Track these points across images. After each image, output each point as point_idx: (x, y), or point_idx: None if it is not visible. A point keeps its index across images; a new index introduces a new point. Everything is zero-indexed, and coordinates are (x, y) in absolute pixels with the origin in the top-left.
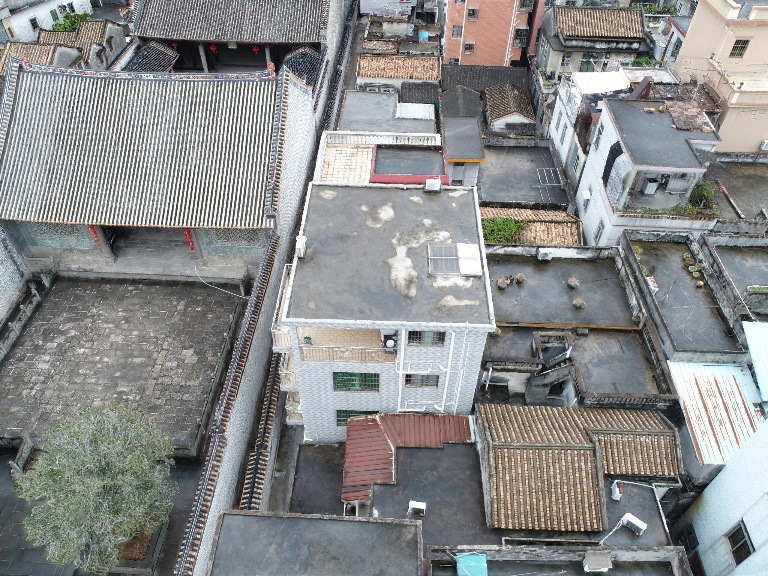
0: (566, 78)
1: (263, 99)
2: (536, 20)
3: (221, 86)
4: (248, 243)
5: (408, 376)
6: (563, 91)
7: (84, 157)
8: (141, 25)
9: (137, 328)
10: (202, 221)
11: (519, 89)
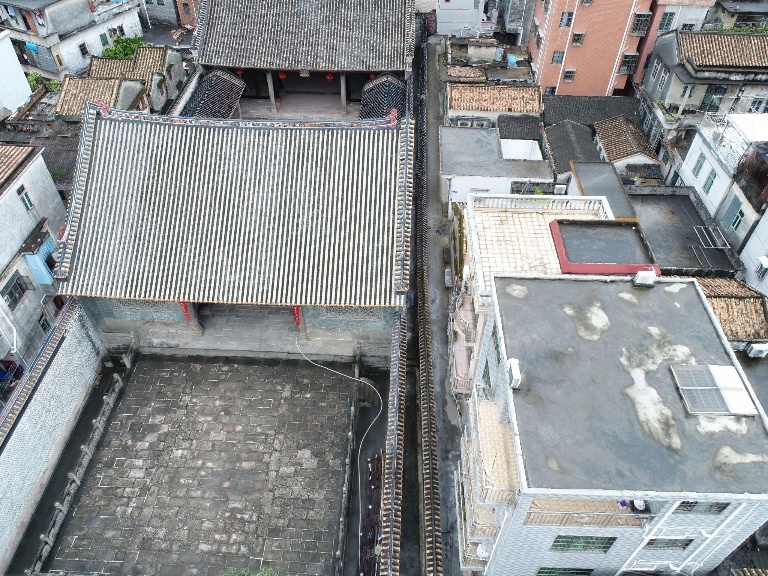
0: (709, 117)
1: (383, 151)
2: (647, 45)
3: (332, 135)
4: (361, 316)
5: (653, 539)
6: (708, 133)
7: (175, 220)
8: (205, 52)
9: (240, 422)
10: (319, 298)
11: (633, 123)
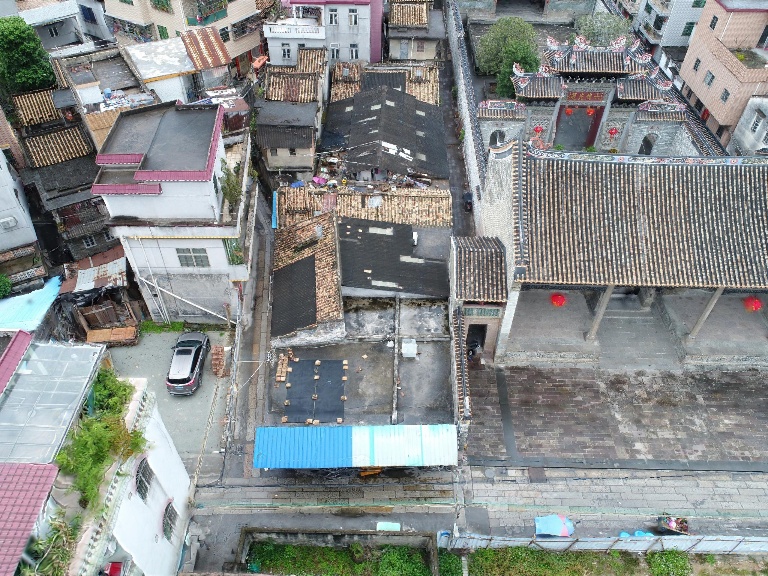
0: None
1: None
2: None
3: None
4: (575, 1)
5: None
6: None
7: None
8: None
9: None
10: None
11: None
